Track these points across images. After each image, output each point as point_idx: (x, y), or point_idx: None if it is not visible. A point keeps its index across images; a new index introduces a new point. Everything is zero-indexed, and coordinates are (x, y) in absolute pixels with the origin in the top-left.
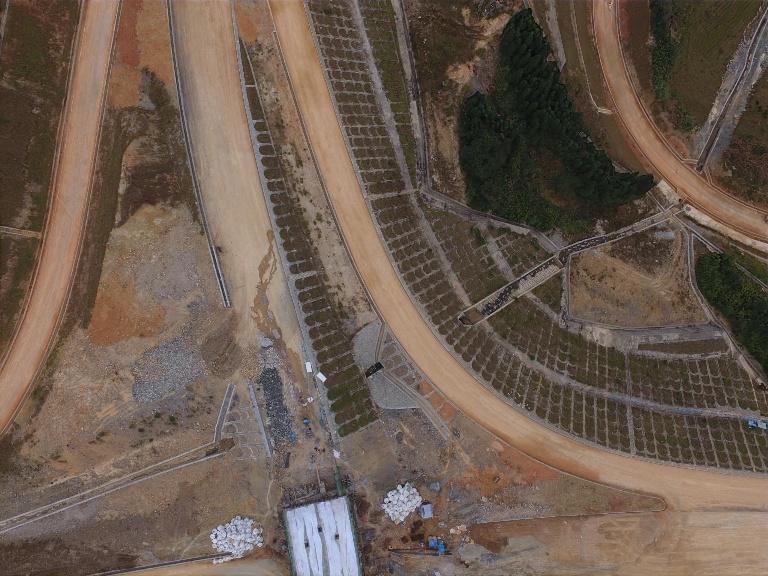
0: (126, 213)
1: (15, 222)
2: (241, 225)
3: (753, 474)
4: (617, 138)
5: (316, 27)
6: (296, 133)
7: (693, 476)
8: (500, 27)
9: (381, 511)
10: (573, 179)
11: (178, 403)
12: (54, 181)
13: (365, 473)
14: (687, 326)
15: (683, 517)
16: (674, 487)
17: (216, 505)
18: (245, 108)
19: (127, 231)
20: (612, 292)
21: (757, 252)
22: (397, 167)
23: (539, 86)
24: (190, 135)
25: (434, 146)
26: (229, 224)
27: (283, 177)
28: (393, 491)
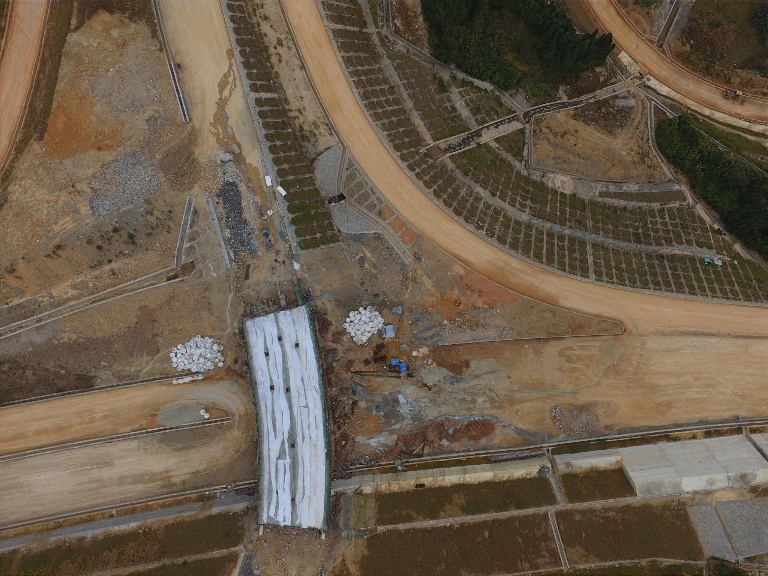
0: (82, 17)
1: None
2: (200, 43)
3: (708, 299)
4: (579, 9)
5: None
6: None
7: (650, 301)
8: None
9: (343, 331)
10: (535, 39)
11: (136, 216)
12: None
13: (326, 288)
14: (647, 182)
15: (641, 341)
16: (632, 312)
17: (176, 327)
18: None
19: (83, 37)
20: (574, 148)
21: (715, 121)
22: (359, 6)
23: None
24: None
25: None
26: (188, 42)
27: (243, 1)
28: (355, 311)
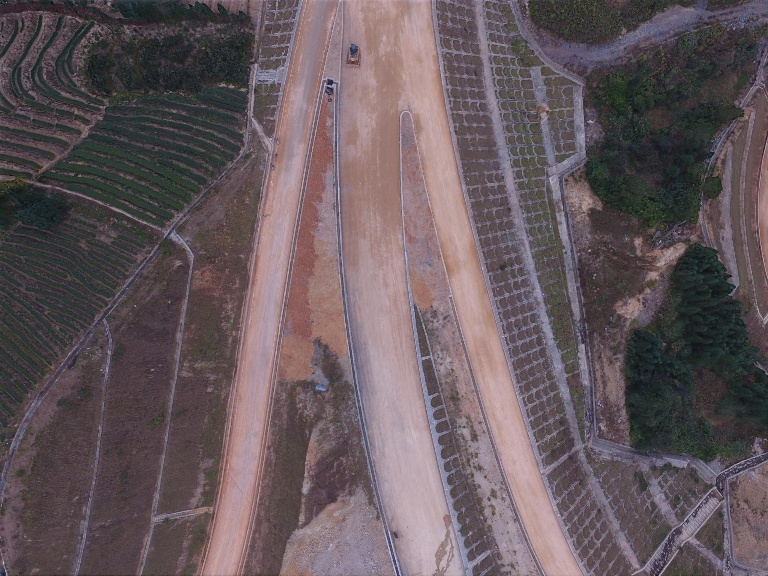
0: (310, 514)
1: (190, 504)
2: (417, 509)
3: None
4: None
5: (494, 290)
6: (471, 405)
7: None
8: (674, 257)
9: None
10: (738, 406)
11: None
12: (225, 454)
13: None
14: None
15: None
16: None
17: None
18: (421, 384)
19: (309, 529)
20: None
21: None
22: (567, 423)
23: (717, 326)
24: (364, 412)
25: (601, 391)
26: (405, 507)
27: (458, 452)
28: None
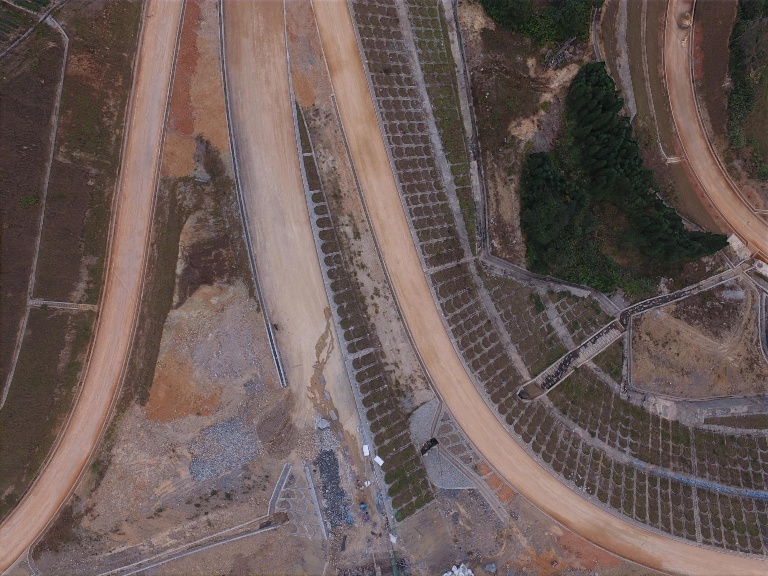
0: (184, 294)
1: (72, 297)
2: (298, 302)
3: None
4: (686, 189)
5: (376, 89)
6: (354, 203)
7: (762, 567)
8: (568, 78)
9: None
10: (639, 238)
11: (234, 482)
12: (109, 253)
13: (421, 557)
14: (756, 395)
15: None
16: None
17: None
18: (302, 179)
19: (184, 312)
20: (676, 359)
21: None
22: (456, 234)
23: (609, 144)
24: (246, 207)
25: (494, 209)
26: (285, 301)
27: (340, 250)
28: (448, 573)
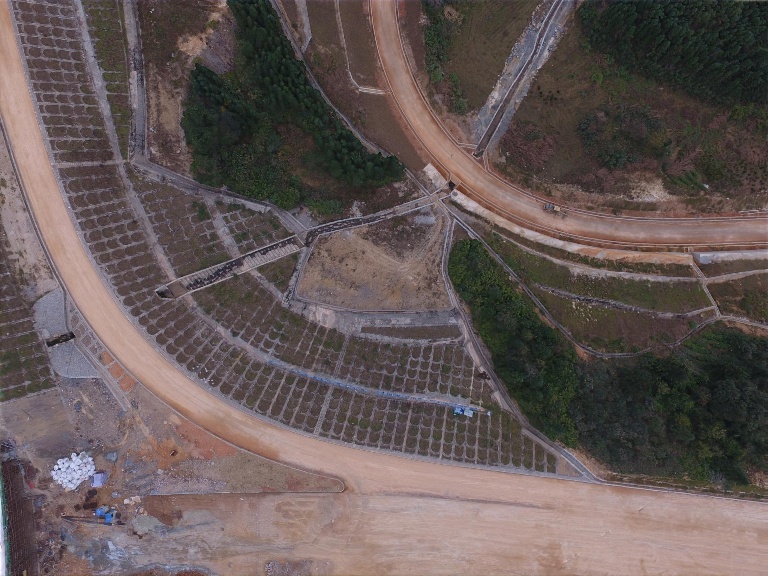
0: None
1: None
2: None
3: (438, 460)
4: (383, 119)
5: None
6: None
7: (376, 459)
8: None
9: (51, 478)
10: (319, 158)
11: None
12: None
13: (27, 439)
14: (428, 312)
15: (364, 500)
16: (356, 469)
17: None
18: None
19: None
20: (351, 274)
21: (522, 241)
22: (105, 137)
23: (267, 60)
24: None
25: (155, 118)
26: None
27: None
28: (64, 459)
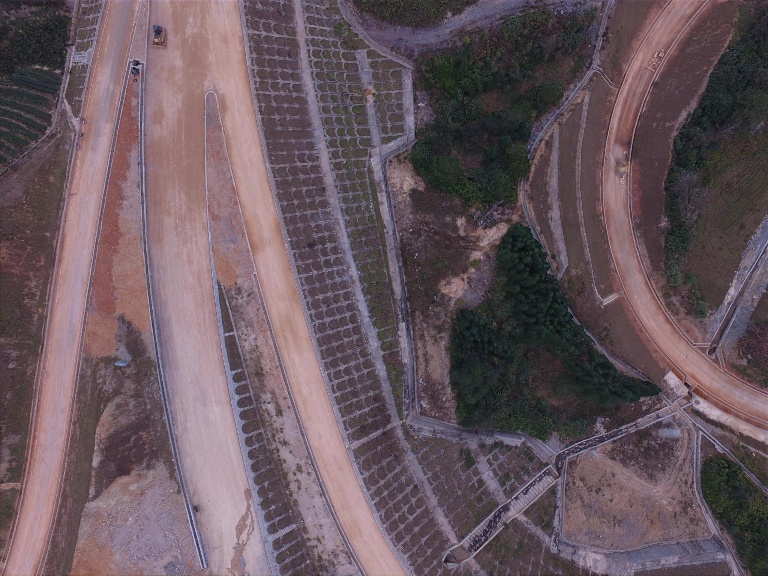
0: (100, 487)
1: None
2: (218, 483)
3: None
4: (623, 328)
5: (298, 267)
6: (276, 381)
7: None
8: (497, 236)
9: None
10: (572, 385)
11: None
12: (32, 431)
13: None
14: (688, 541)
15: None
16: None
17: None
18: (223, 359)
19: (102, 502)
20: (609, 506)
21: None
22: (383, 400)
23: (537, 304)
24: (167, 387)
25: (423, 369)
26: (206, 482)
27: (262, 428)
28: None
